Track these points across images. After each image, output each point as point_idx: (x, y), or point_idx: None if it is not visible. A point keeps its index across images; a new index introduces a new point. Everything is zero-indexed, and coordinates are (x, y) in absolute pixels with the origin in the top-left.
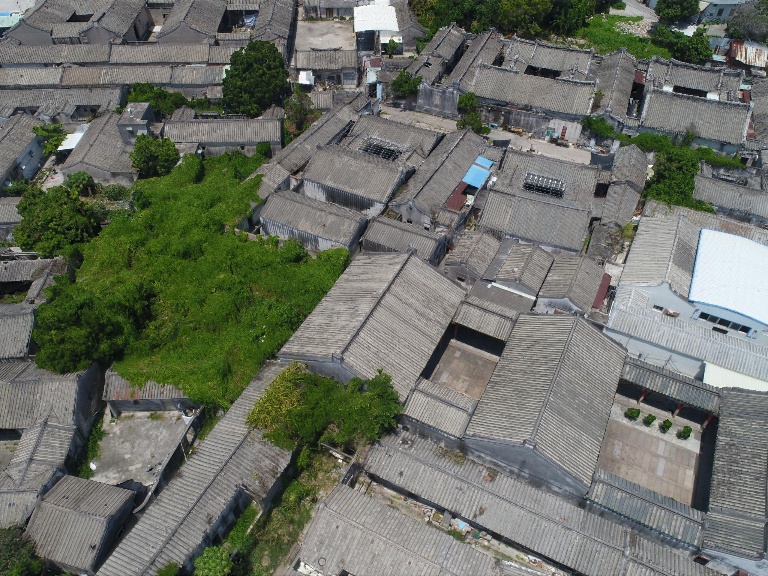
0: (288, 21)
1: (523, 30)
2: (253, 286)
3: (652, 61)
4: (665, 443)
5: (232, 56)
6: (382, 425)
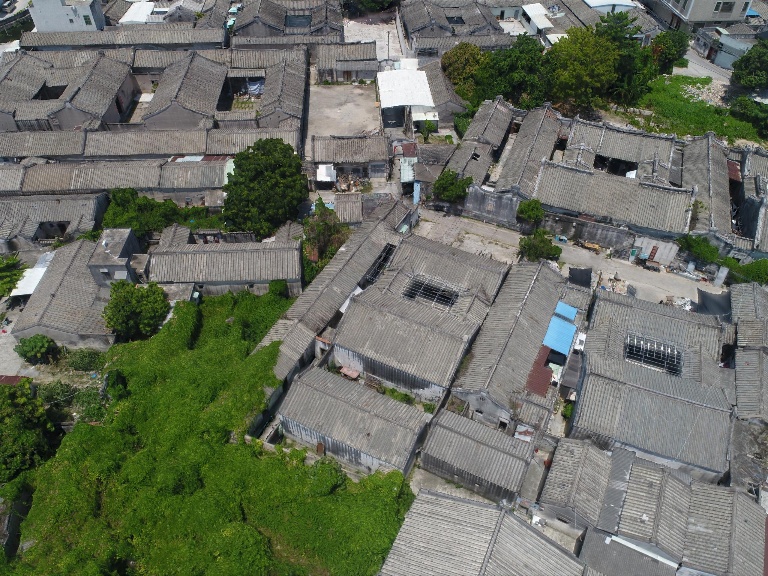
0: (301, 93)
1: (583, 105)
2: (272, 536)
3: (751, 152)
4: None
5: (236, 159)
6: None
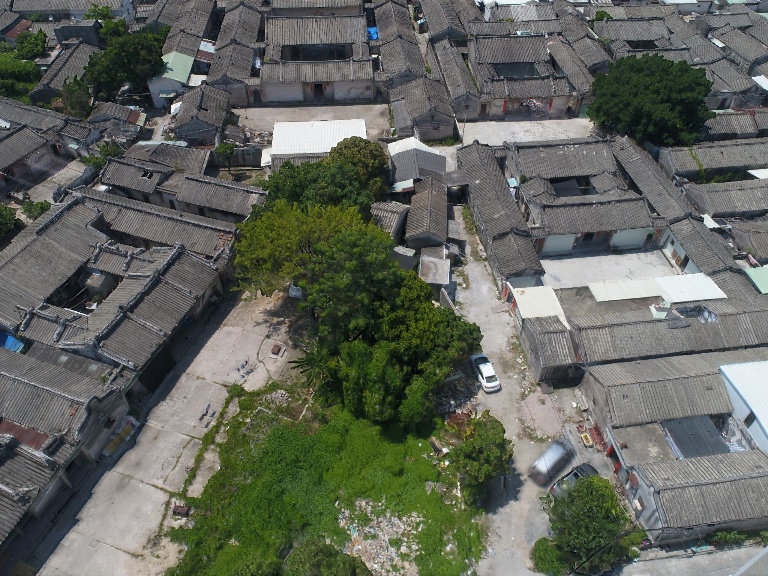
0: (313, 79)
1: None
2: None
3: None
4: None
5: None
6: None
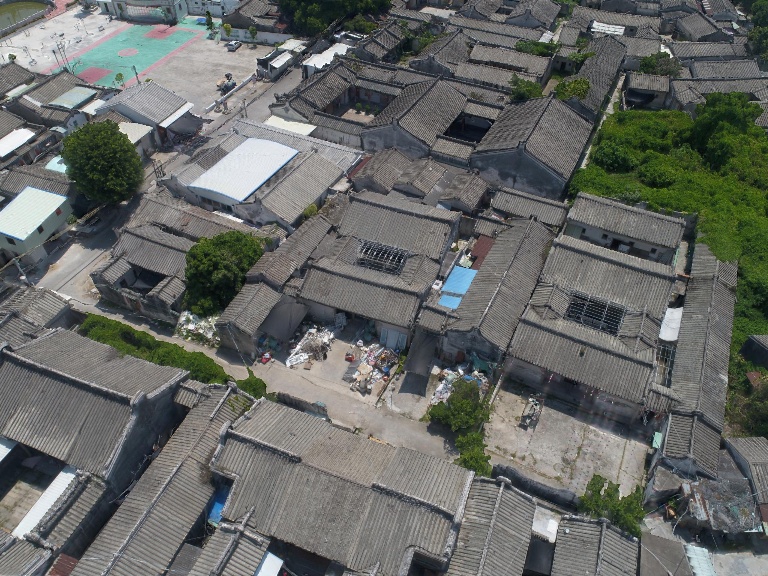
0: None
1: None
2: None
3: None
4: None
5: None
6: None
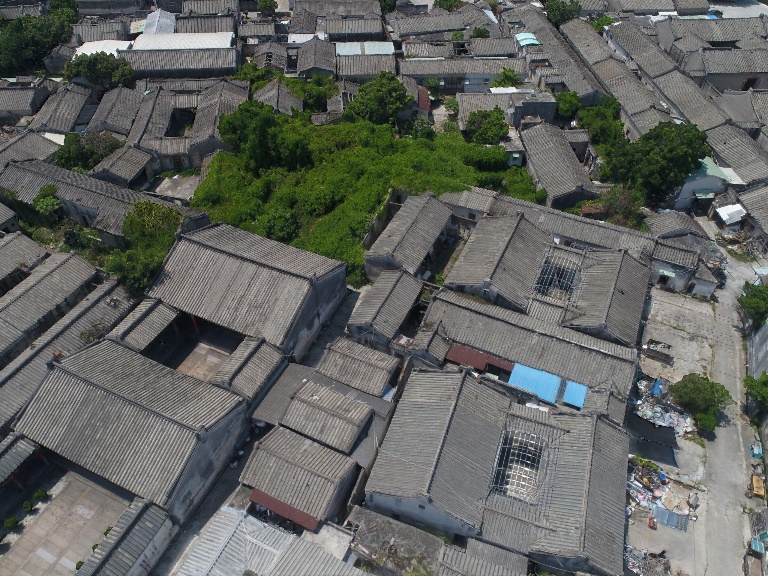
0: None
1: None
2: (327, 215)
3: None
4: (72, 570)
5: (660, 122)
6: (132, 285)
